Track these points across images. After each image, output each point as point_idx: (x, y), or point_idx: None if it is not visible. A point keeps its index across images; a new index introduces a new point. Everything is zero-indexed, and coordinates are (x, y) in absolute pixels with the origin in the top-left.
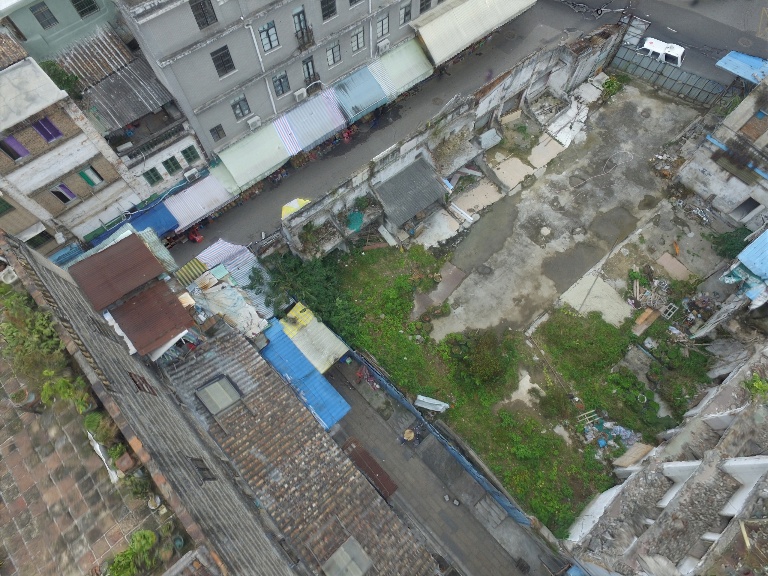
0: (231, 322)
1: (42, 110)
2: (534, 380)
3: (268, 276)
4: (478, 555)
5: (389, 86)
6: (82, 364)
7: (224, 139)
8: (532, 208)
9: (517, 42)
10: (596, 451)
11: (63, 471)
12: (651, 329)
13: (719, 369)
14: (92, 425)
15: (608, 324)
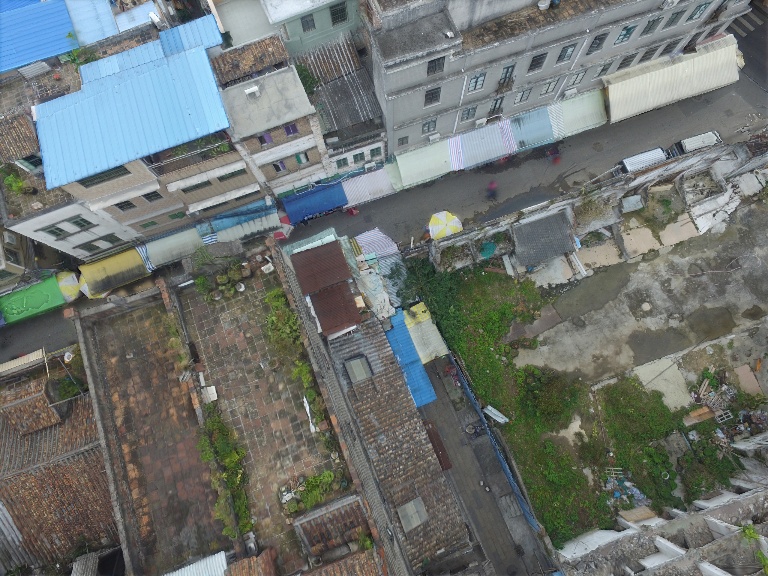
0: (370, 303)
1: (295, 120)
2: (583, 426)
3: (406, 274)
4: (490, 530)
5: (560, 128)
6: (311, 356)
7: (405, 145)
8: (643, 281)
9: (701, 106)
10: (609, 498)
11: (284, 413)
12: (700, 425)
13: (741, 481)
14: (311, 398)
15: (665, 406)
